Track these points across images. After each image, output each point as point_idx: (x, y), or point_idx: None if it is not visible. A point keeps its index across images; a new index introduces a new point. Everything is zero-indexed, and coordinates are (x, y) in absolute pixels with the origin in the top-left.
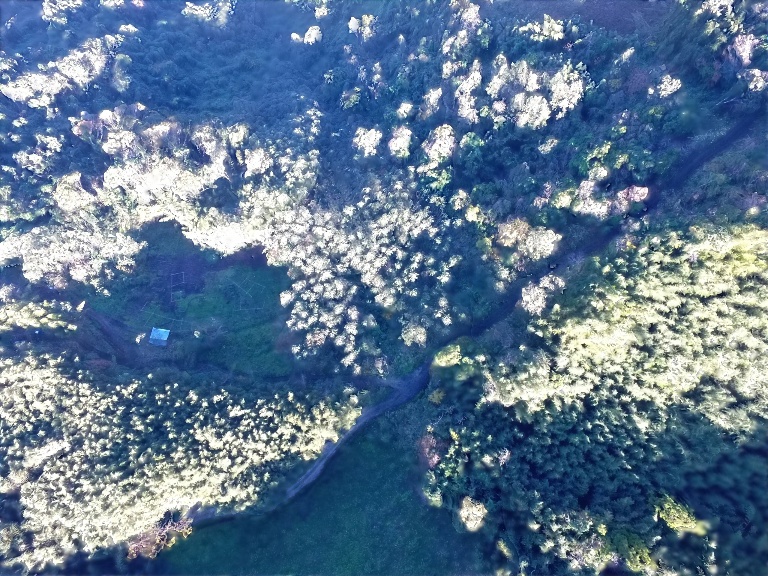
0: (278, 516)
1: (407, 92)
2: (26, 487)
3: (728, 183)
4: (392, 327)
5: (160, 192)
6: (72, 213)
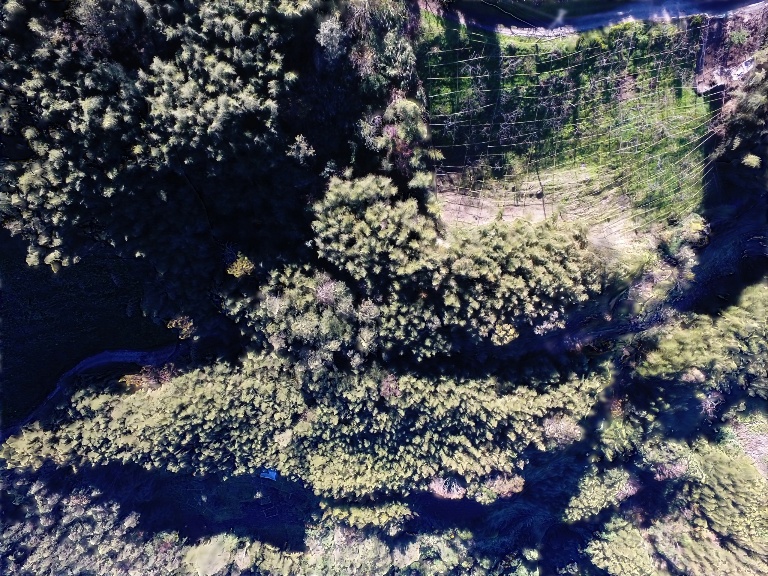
0: (86, 350)
1: None
2: (300, 411)
3: None
4: (12, 503)
5: (310, 574)
6: (366, 574)
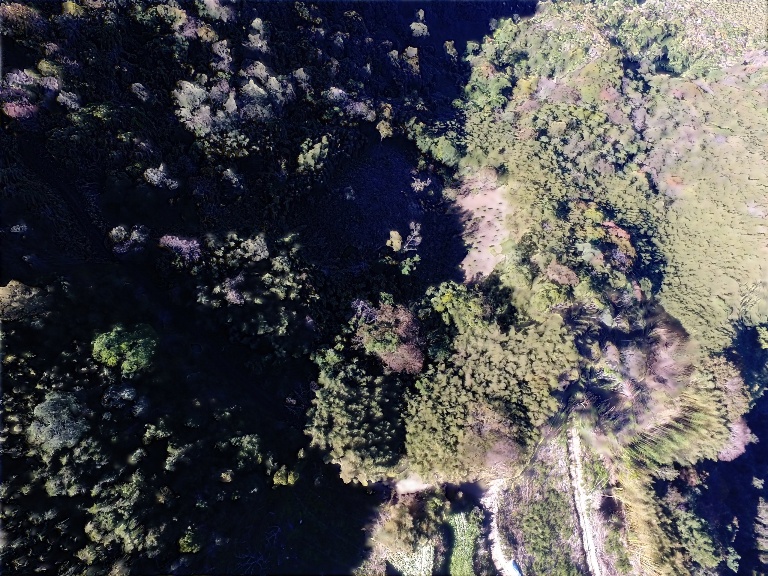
0: None
1: (303, 59)
2: None
3: (3, 187)
4: None
5: None
6: None
